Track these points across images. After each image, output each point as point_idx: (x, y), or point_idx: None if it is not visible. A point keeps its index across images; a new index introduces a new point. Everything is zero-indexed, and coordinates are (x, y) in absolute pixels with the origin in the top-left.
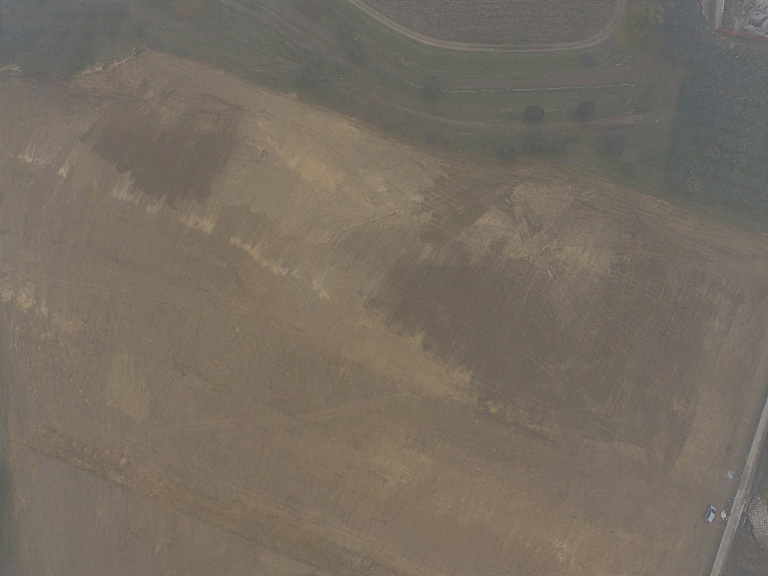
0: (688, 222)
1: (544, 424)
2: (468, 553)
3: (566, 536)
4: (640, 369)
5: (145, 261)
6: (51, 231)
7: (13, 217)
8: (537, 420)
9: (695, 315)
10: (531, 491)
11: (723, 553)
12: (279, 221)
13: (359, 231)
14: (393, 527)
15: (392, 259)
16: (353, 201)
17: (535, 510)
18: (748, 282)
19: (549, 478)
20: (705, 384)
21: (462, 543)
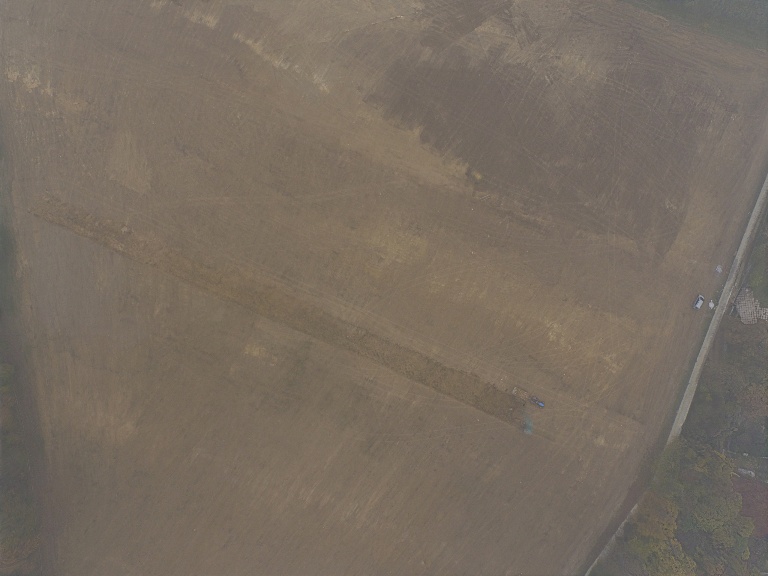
0: (684, 37)
1: (538, 215)
2: (460, 328)
3: (557, 317)
4: (633, 169)
5: (149, 51)
6: (57, 20)
7: (20, 6)
8: (531, 211)
9: (689, 122)
10: (524, 275)
11: (710, 336)
12: (282, 21)
13: (360, 33)
14: (388, 302)
15: (392, 60)
16: (355, 6)
17: (527, 292)
18: (742, 93)
19: (541, 264)
20: (697, 185)
21: (455, 319)
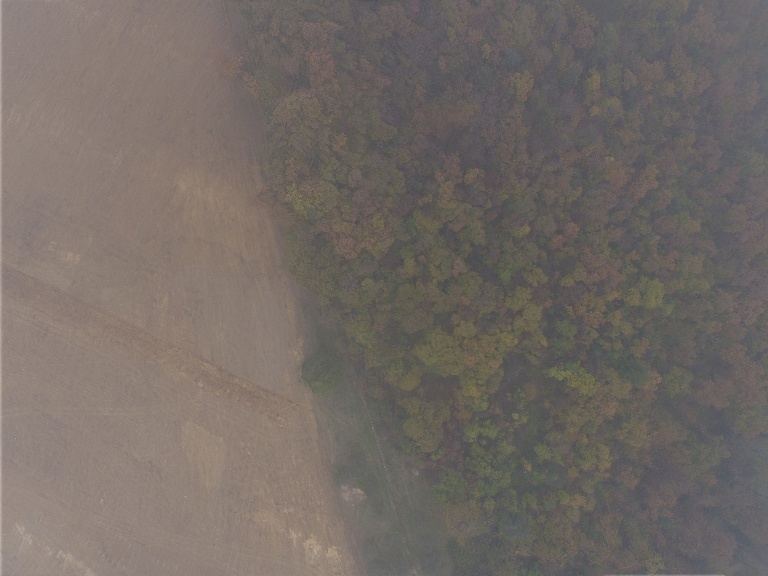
0: None
1: None
2: None
3: None
4: None
5: None
6: None
7: None
8: None
9: None
10: None
11: None
12: None
13: None
14: None
15: None
16: None
17: None
18: None
19: None
20: None
21: None
